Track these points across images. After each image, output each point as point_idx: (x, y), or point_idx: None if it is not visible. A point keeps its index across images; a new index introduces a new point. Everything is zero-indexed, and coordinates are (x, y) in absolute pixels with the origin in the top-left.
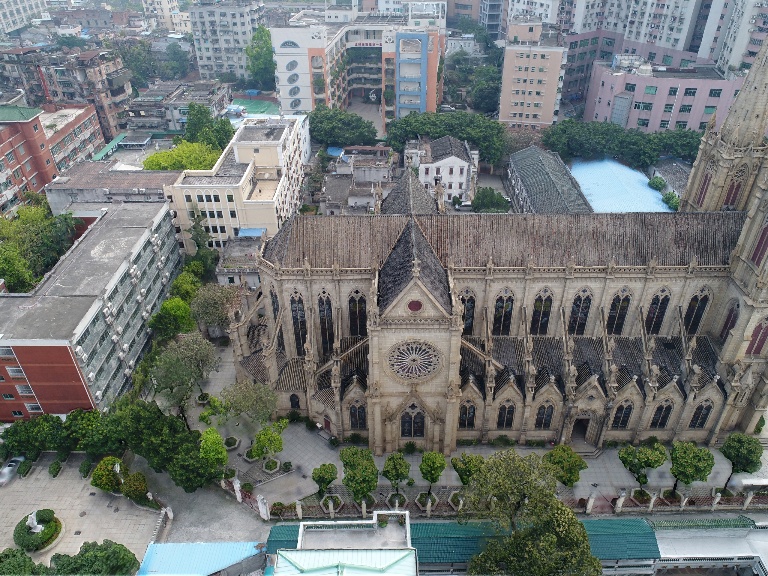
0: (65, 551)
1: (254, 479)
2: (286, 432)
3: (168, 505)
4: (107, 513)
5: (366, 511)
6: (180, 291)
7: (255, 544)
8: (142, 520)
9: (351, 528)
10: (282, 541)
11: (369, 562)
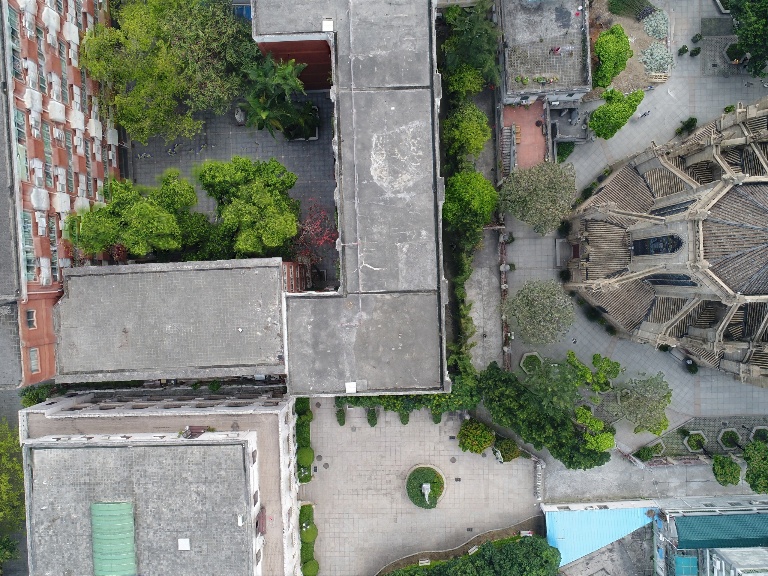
0: (455, 498)
1: (610, 413)
2: (633, 351)
3: (533, 448)
4: (476, 459)
5: (731, 450)
6: (466, 148)
7: (645, 511)
8: (513, 465)
9: None
10: (692, 541)
11: None
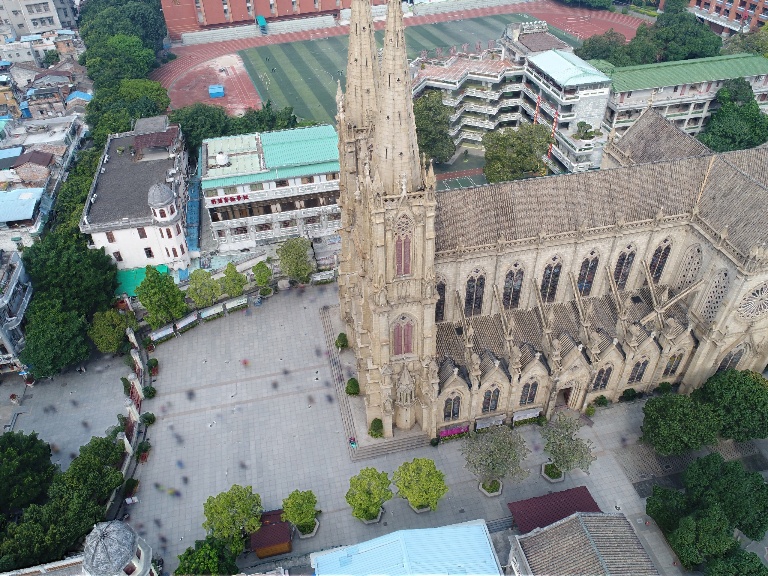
0: None
1: None
2: None
3: None
4: None
5: None
6: None
7: None
8: None
9: (600, 146)
10: None
11: (577, 81)
